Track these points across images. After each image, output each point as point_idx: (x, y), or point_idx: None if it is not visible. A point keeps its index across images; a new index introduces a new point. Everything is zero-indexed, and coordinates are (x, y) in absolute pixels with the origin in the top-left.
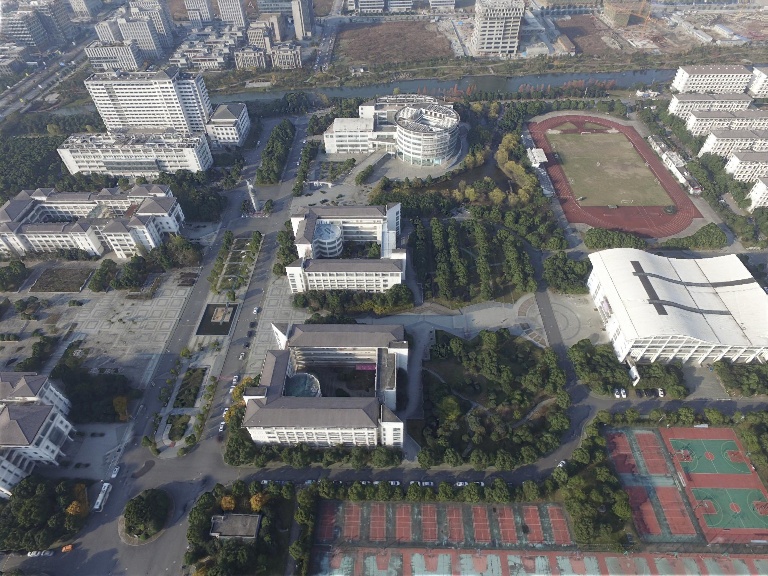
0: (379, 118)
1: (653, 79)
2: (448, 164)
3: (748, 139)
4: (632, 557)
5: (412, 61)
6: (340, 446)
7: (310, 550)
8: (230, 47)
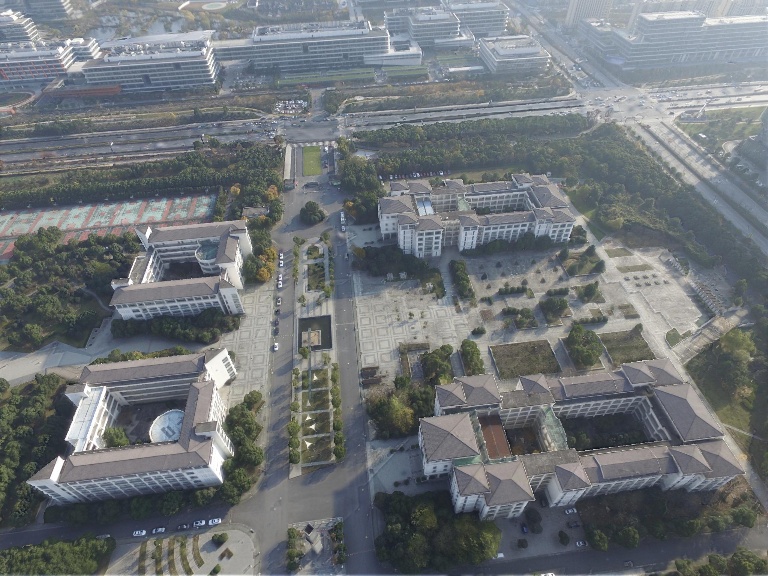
0: None
1: None
2: None
3: None
4: None
5: None
6: None
7: None
8: None
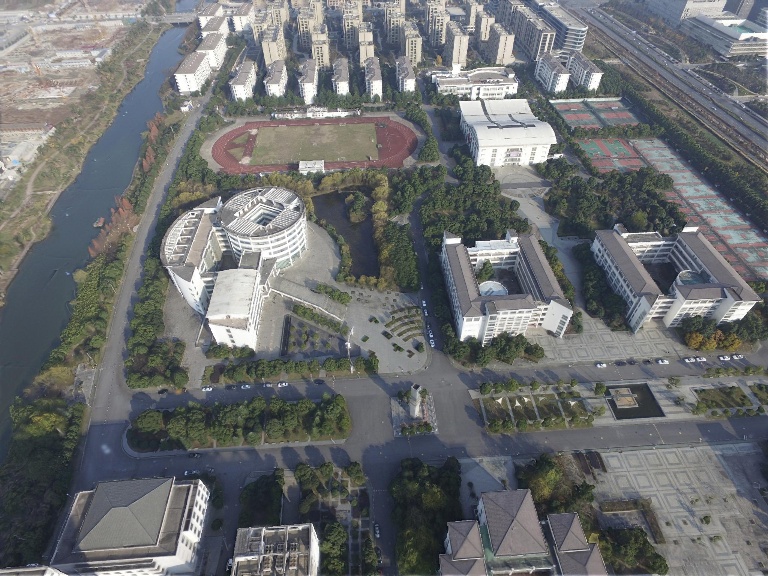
0: None
1: (165, 96)
2: None
3: None
4: None
5: None
6: None
7: None
8: None
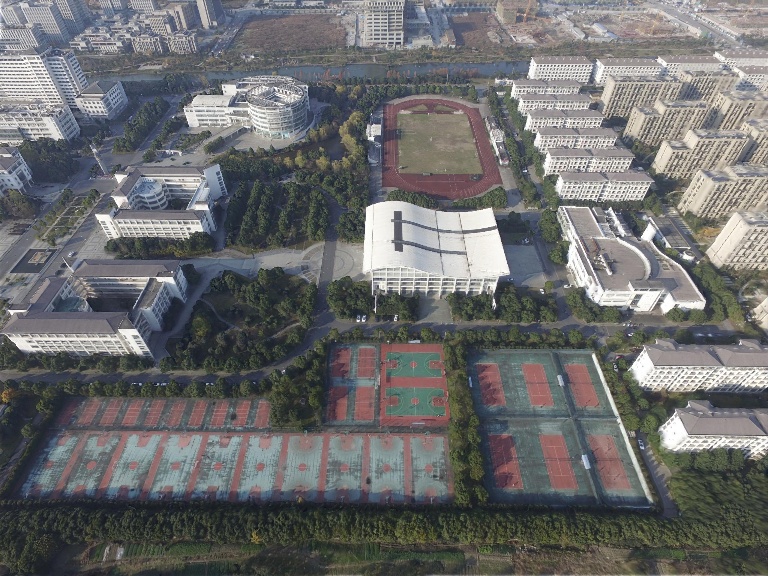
0: (242, 96)
1: (513, 69)
2: (296, 137)
3: (559, 118)
4: (312, 436)
5: (302, 49)
6: (94, 354)
7: (41, 431)
8: (133, 33)
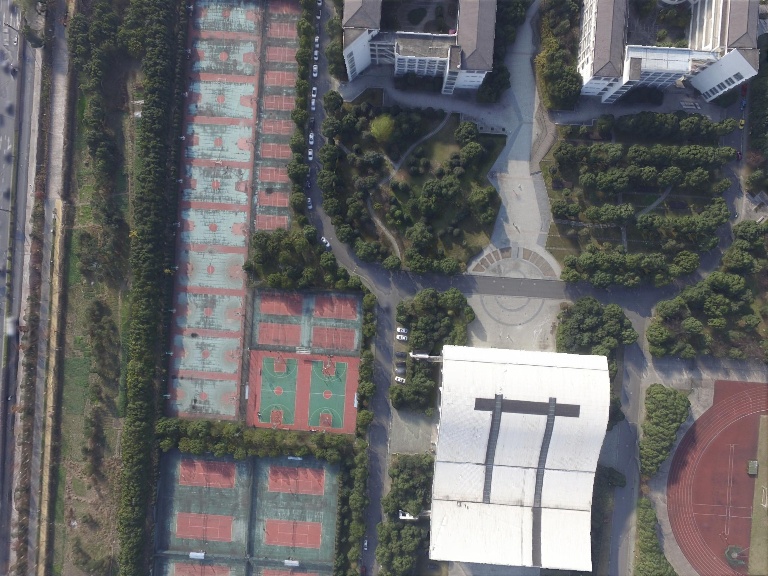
0: None
1: None
2: None
3: None
4: (243, 278)
5: None
6: None
7: None
8: None
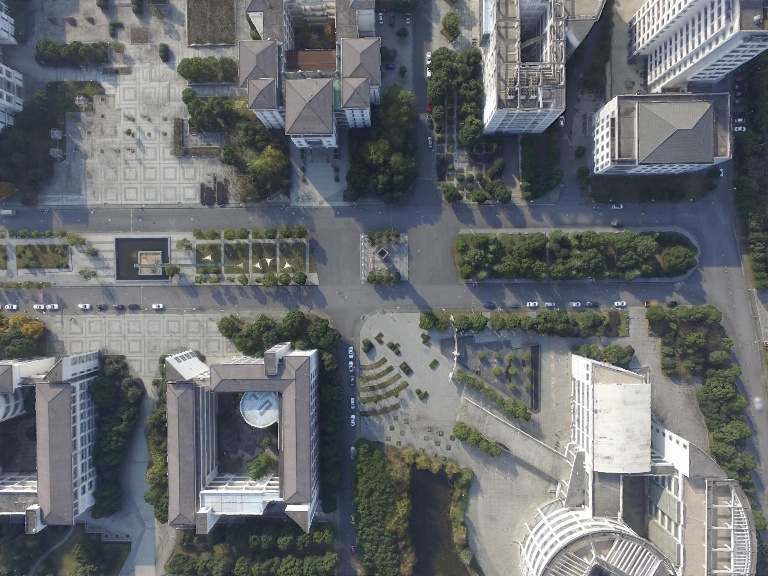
0: None
1: None
2: None
3: None
4: None
5: None
6: None
7: None
8: None
